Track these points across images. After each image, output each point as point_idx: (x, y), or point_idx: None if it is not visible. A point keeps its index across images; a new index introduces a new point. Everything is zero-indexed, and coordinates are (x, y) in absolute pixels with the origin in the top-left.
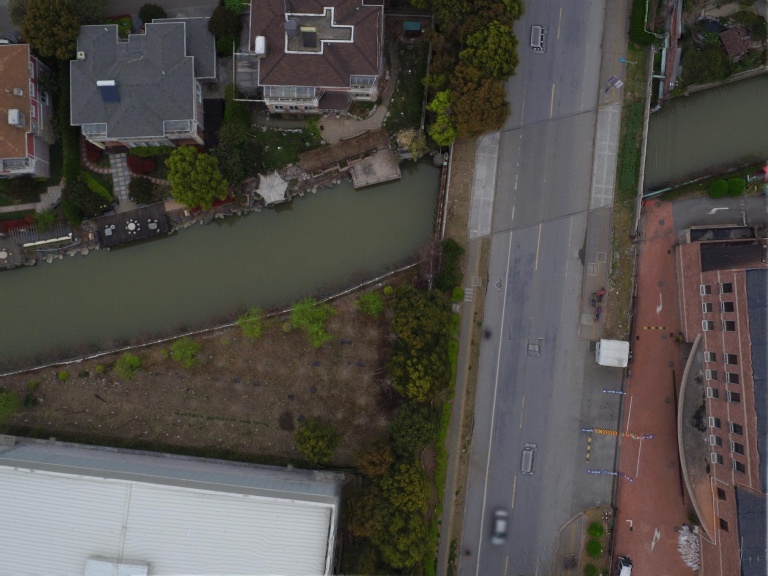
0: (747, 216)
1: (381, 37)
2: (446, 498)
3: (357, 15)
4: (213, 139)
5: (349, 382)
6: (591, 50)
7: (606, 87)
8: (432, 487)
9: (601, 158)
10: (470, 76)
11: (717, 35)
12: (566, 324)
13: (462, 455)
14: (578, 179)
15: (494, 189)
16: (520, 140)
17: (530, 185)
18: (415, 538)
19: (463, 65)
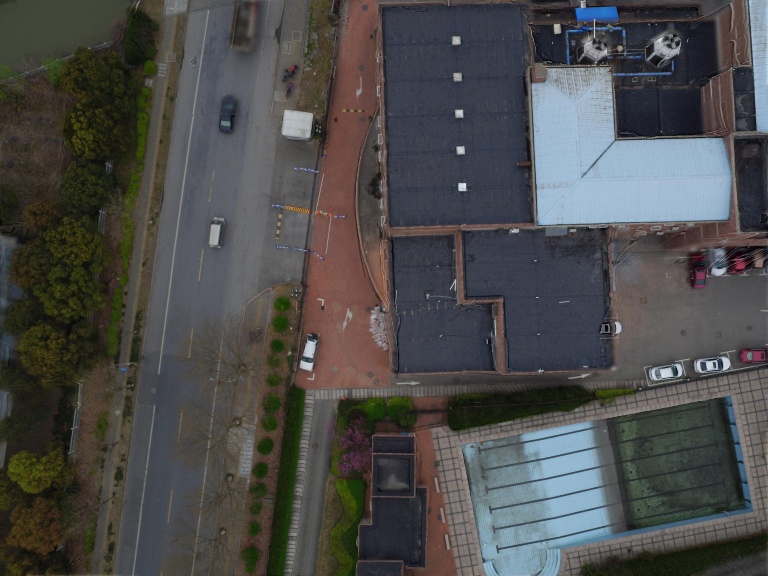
0: (452, 3)
1: None
2: (132, 269)
3: None
4: None
5: (46, 158)
6: None
7: None
8: (114, 254)
9: None
10: None
11: None
12: (259, 101)
13: (150, 227)
14: None
15: None
16: None
17: None
18: (78, 291)
19: None
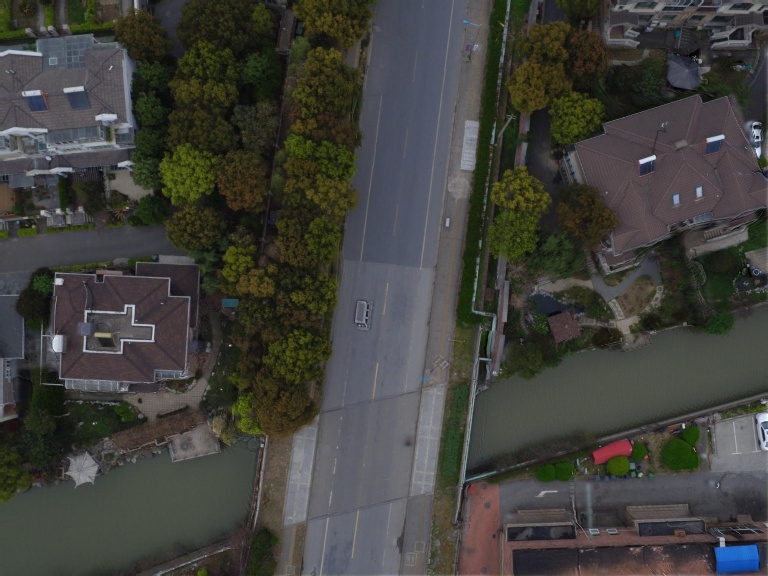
0: (576, 500)
1: (196, 318)
2: None
3: (162, 310)
4: (25, 416)
5: None
6: (417, 327)
7: (431, 368)
8: None
9: (423, 443)
10: (270, 386)
11: (545, 319)
12: None
13: None
14: (399, 464)
15: (311, 474)
16: (340, 422)
17: (349, 470)
18: None
19: (263, 373)
